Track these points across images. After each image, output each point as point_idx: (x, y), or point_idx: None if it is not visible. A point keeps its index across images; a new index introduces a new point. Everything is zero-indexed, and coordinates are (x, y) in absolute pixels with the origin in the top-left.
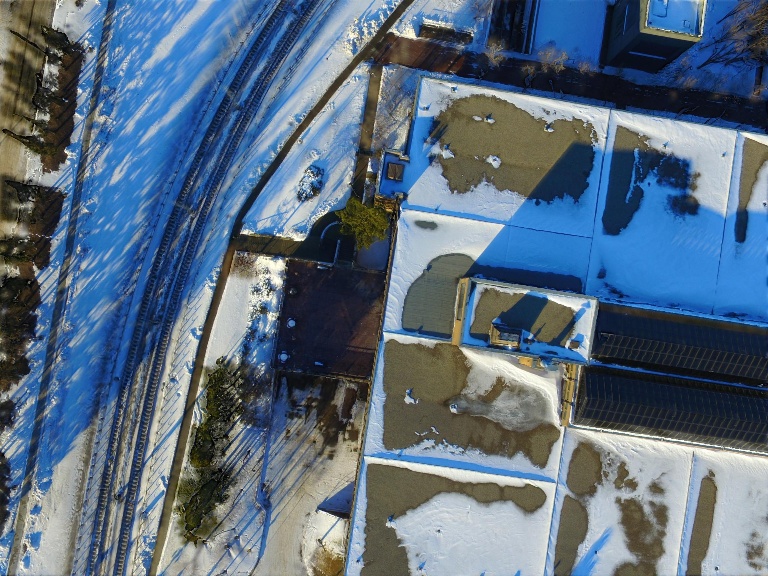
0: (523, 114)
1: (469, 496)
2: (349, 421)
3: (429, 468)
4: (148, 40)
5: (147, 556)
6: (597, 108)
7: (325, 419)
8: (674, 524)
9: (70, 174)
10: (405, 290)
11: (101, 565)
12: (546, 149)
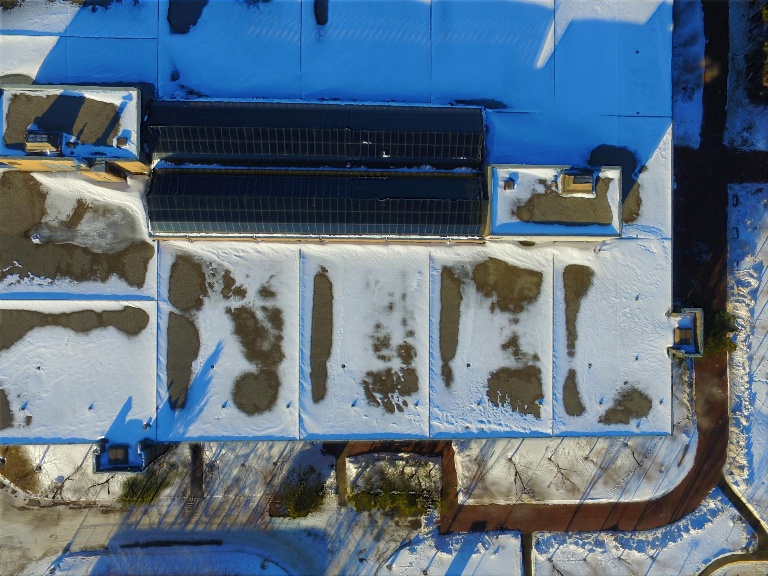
0: None
1: (65, 327)
2: None
3: (16, 304)
4: None
5: None
6: None
7: None
8: (290, 326)
9: None
10: None
11: None
12: None
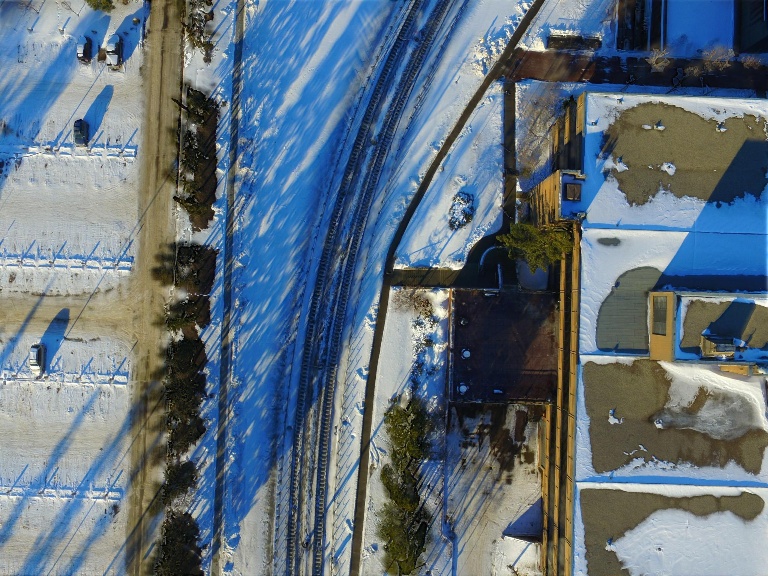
0: (693, 117)
1: (686, 511)
2: (523, 444)
3: (642, 487)
4: (278, 87)
5: None
6: (767, 101)
7: (499, 444)
8: None
9: (219, 230)
10: (596, 310)
11: None
12: (720, 150)
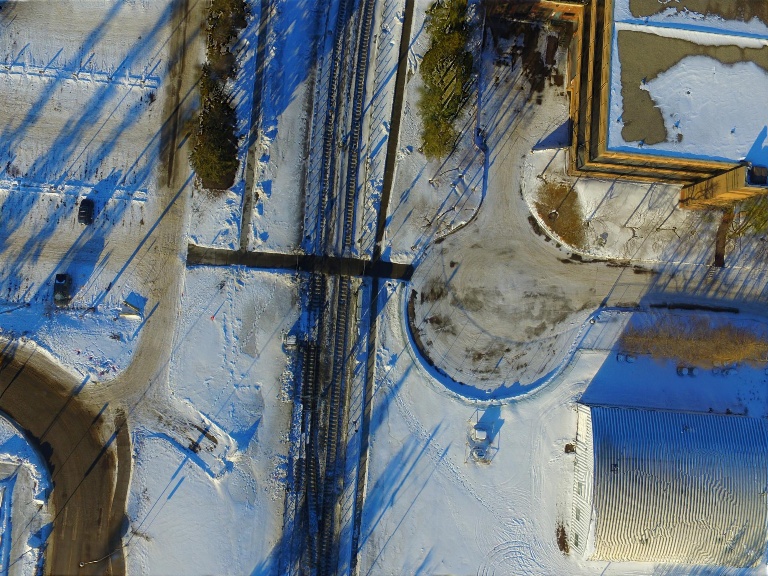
0: None
1: (713, 58)
2: (553, 67)
3: (675, 32)
4: None
5: (376, 198)
6: None
7: (531, 66)
8: None
9: None
10: None
11: (331, 211)
12: None
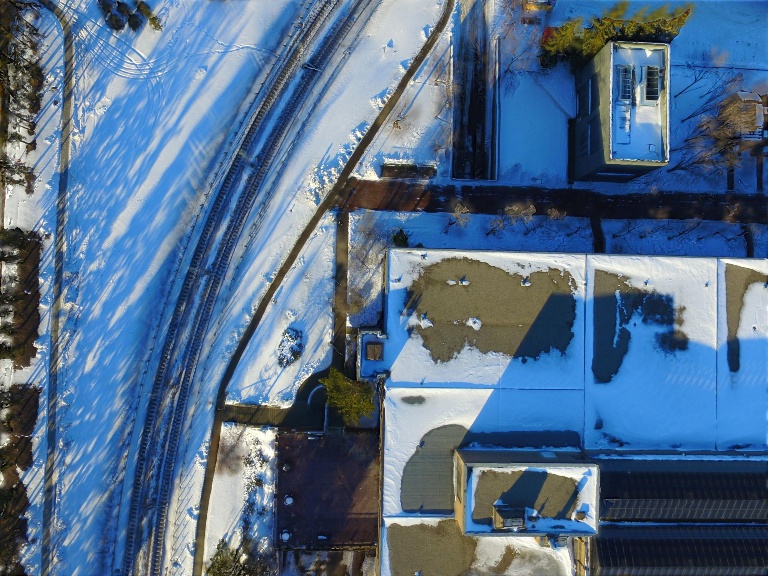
0: (498, 272)
1: None
2: None
3: None
4: (105, 218)
5: None
6: (572, 255)
7: None
8: None
9: (42, 368)
10: (400, 470)
11: None
12: (526, 304)
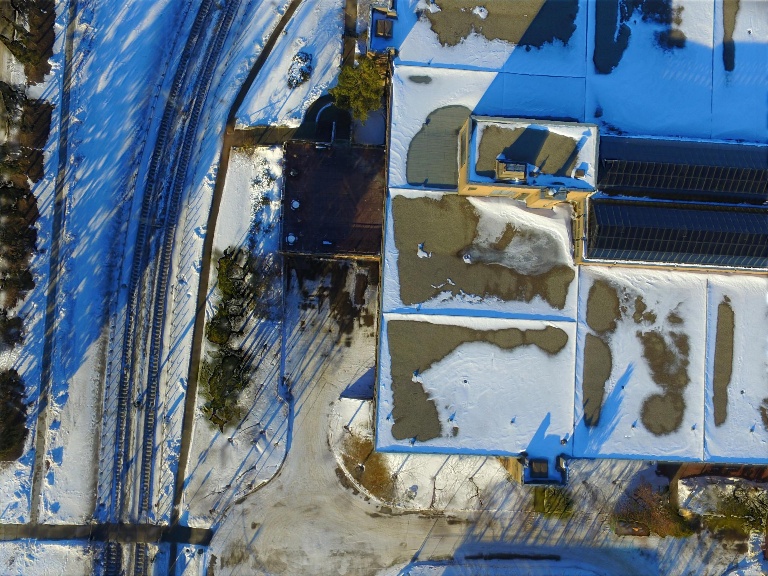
0: None
1: (492, 343)
2: (363, 307)
3: (449, 319)
4: None
5: (173, 460)
6: None
7: (338, 307)
8: (696, 351)
9: (56, 85)
10: (406, 145)
11: (127, 475)
12: None
